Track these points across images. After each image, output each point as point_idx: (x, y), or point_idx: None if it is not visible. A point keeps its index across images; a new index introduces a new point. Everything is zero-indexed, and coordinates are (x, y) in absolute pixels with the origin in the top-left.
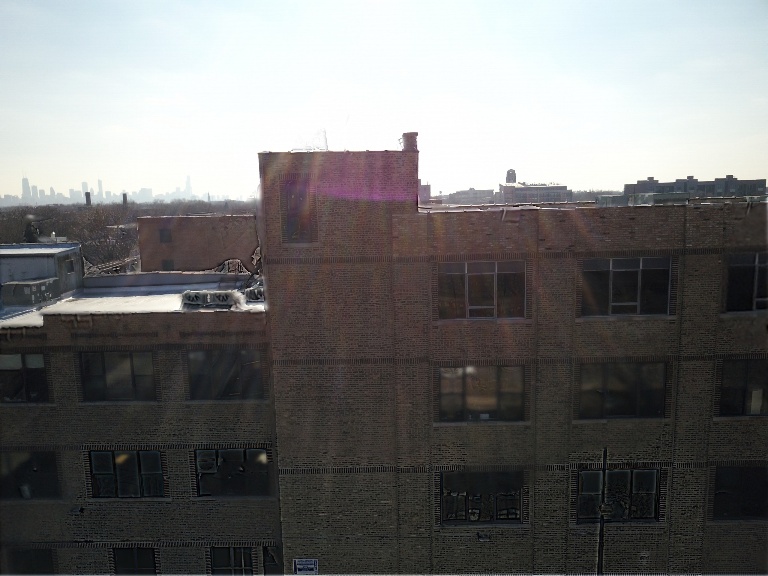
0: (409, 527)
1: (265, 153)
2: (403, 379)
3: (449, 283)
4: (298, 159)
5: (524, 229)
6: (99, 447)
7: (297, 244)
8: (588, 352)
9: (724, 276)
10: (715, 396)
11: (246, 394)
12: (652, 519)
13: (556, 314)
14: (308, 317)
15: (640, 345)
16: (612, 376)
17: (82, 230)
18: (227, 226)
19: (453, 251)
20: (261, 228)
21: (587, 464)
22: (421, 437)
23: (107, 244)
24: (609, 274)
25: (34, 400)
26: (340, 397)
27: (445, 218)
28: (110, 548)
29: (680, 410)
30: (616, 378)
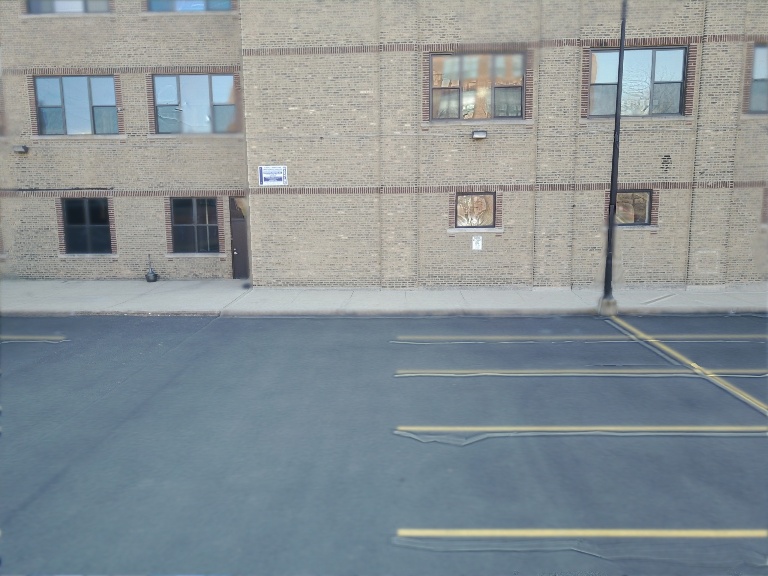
0: (392, 122)
1: None
2: None
3: None
4: None
5: None
6: (45, 70)
7: None
8: None
9: None
10: None
11: (211, 5)
12: (677, 114)
13: None
14: None
15: None
16: None
17: None
18: None
19: None
20: None
21: (602, 40)
22: (407, 4)
23: None
24: None
25: None
26: None
27: None
28: (58, 198)
29: None
30: None
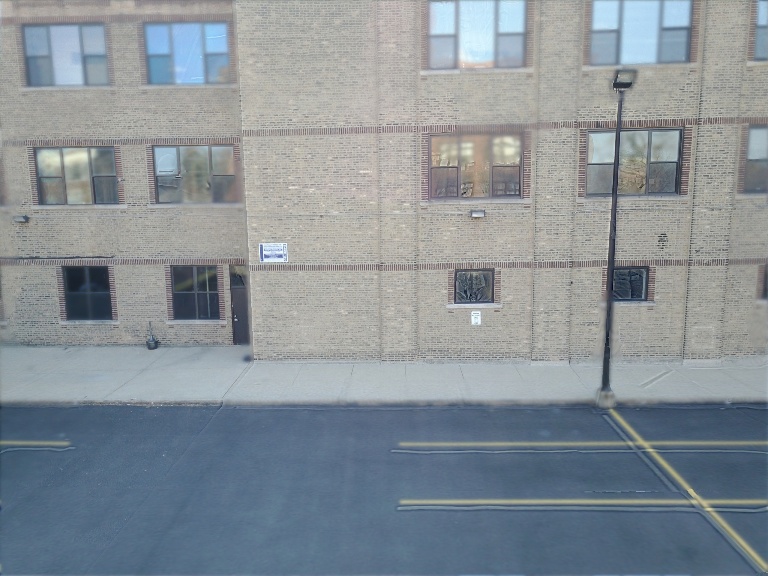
0: (392, 201)
1: None
2: (386, 14)
3: None
4: None
5: None
6: (45, 141)
7: None
8: None
9: None
10: (750, 34)
11: (210, 78)
12: (673, 193)
13: None
14: None
15: None
16: (630, 4)
17: None
18: None
19: None
20: None
21: (598, 122)
22: (406, 86)
23: None
24: None
25: None
26: (313, 38)
27: None
28: (59, 266)
29: (708, 50)
30: (634, 7)
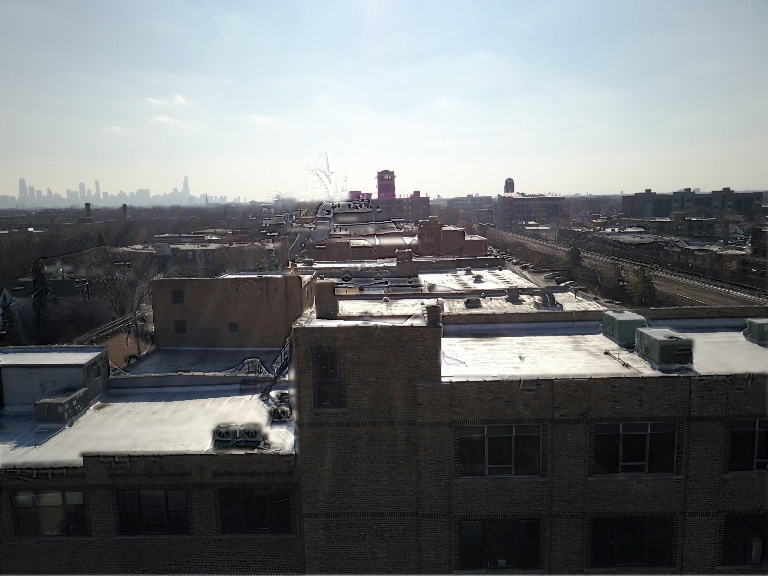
0: None
1: (298, 327)
2: (426, 531)
3: (470, 446)
4: (329, 333)
5: (540, 397)
6: None
7: (327, 409)
8: (599, 507)
9: (727, 440)
10: (718, 547)
11: (274, 529)
12: None
13: (570, 474)
14: (337, 474)
15: (648, 501)
16: (622, 531)
17: (89, 267)
18: (238, 288)
19: (474, 416)
20: (294, 394)
21: None
22: None
23: (114, 281)
24: (619, 437)
25: (73, 534)
26: (366, 547)
27: (466, 386)
28: None
29: (685, 561)
30: (626, 532)
